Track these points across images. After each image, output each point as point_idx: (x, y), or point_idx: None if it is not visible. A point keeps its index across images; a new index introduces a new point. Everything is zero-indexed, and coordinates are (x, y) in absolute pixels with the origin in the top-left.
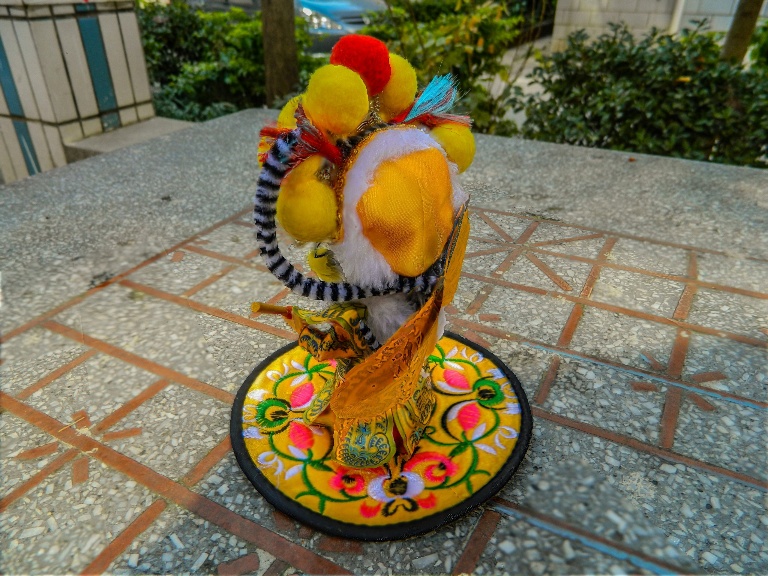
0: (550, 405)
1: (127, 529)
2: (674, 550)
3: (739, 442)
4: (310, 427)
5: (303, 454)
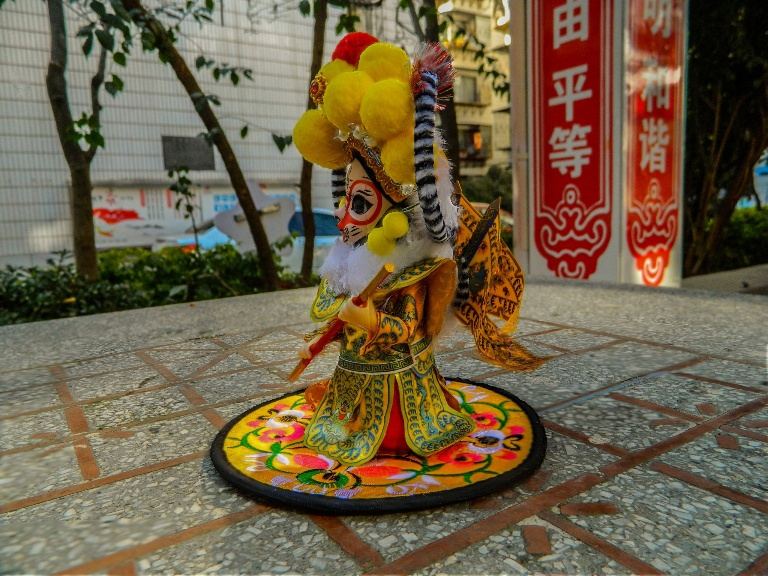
0: None
1: None
2: (593, 384)
3: (520, 353)
4: (369, 465)
5: (407, 473)
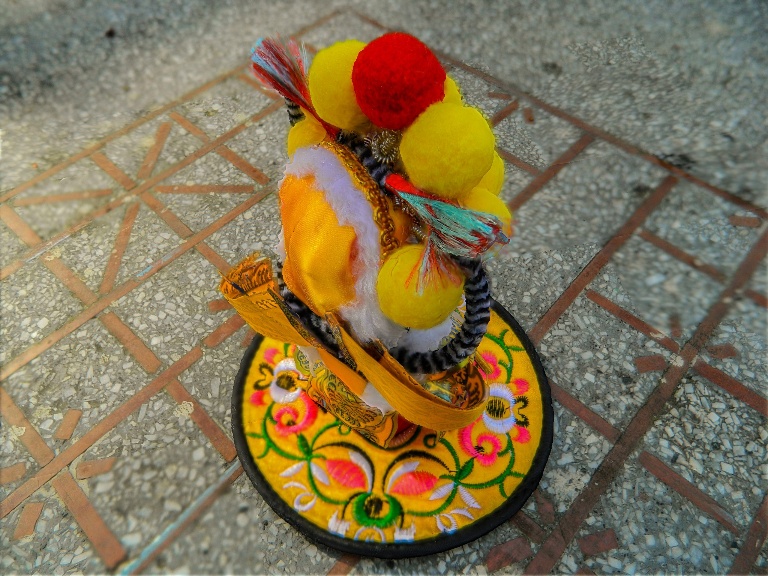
0: None
1: None
2: None
3: None
4: None
5: None
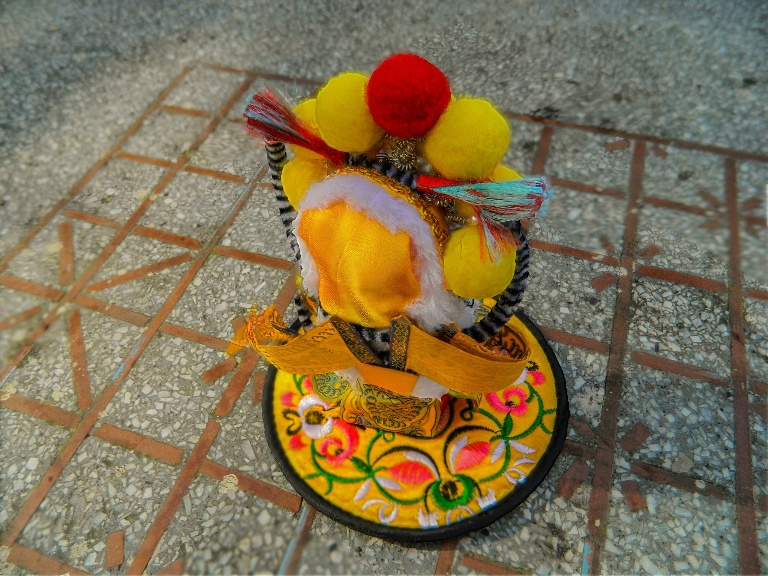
0: (463, 574)
1: (268, 257)
2: None
3: None
4: None
5: None
